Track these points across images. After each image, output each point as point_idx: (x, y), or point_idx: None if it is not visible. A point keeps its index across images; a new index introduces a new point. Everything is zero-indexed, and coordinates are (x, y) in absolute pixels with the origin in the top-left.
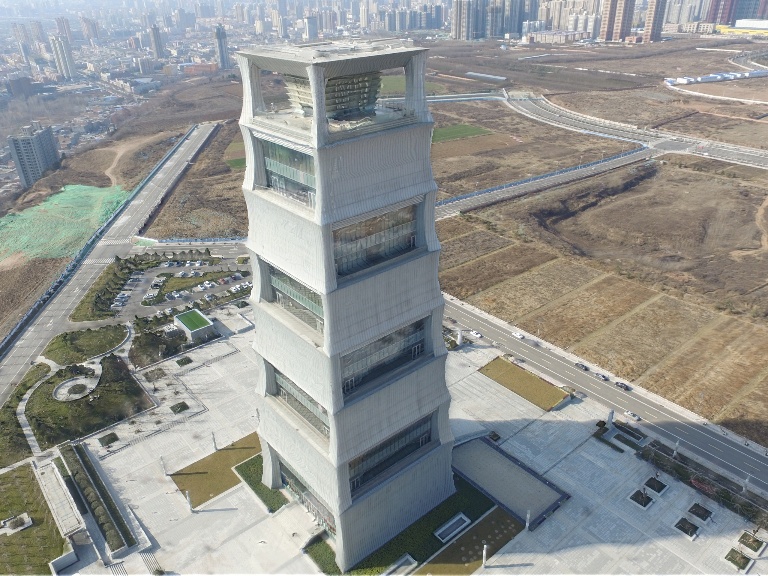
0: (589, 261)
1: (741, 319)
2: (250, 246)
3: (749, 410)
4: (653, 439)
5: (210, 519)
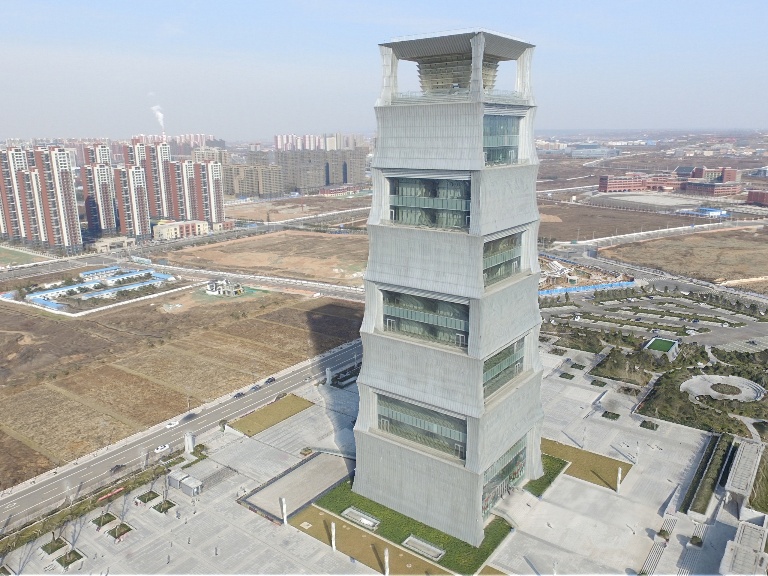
0: (1, 393)
1: (172, 342)
2: (486, 231)
3: (297, 348)
4: (335, 375)
5: (552, 573)
